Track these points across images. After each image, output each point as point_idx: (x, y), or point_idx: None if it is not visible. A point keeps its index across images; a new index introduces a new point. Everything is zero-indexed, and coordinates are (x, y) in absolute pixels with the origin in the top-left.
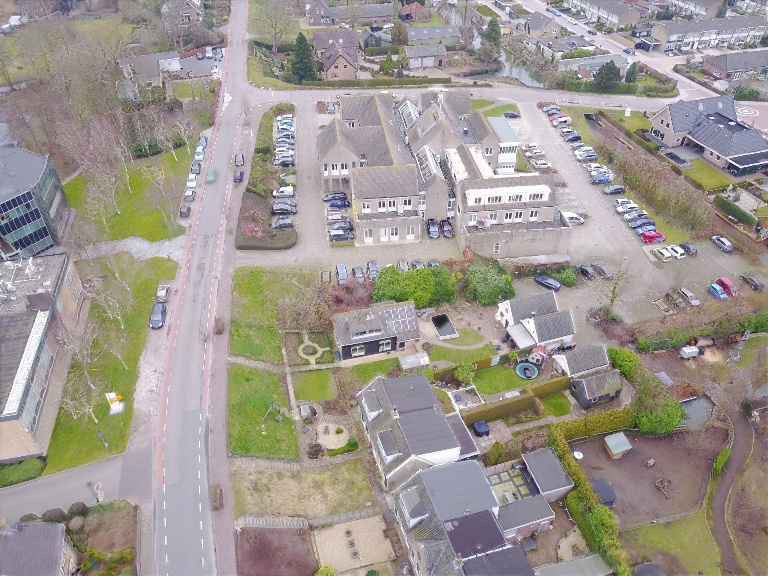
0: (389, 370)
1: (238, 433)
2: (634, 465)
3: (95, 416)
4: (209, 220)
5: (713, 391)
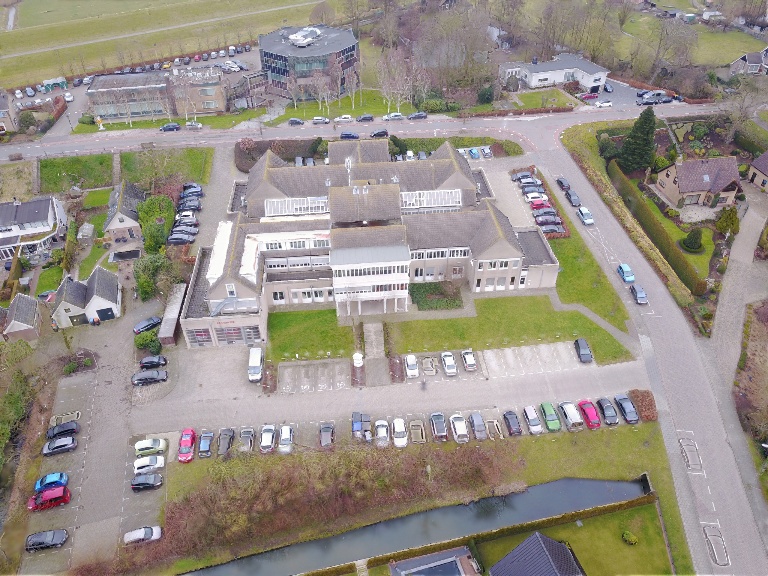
0: (96, 229)
1: (57, 162)
2: None
3: (104, 126)
4: (283, 133)
5: None
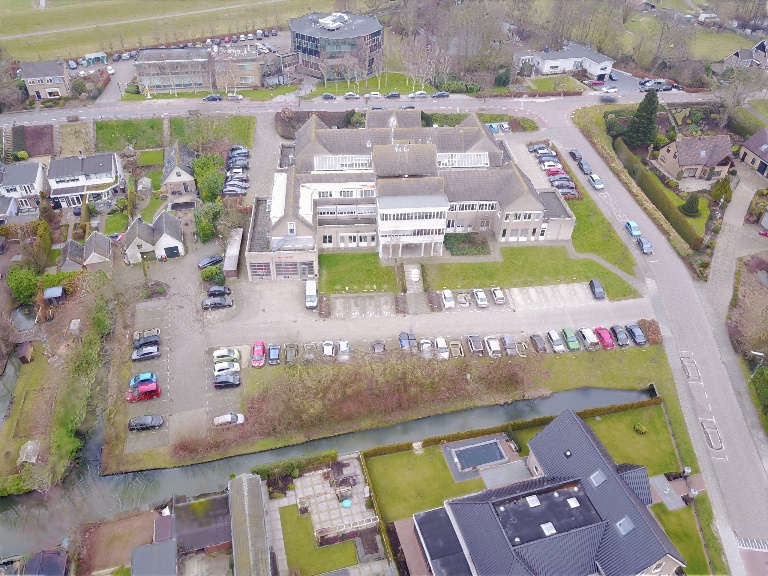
0: None
1: (111, 124)
2: (6, 271)
3: None
4: (317, 105)
5: (33, 334)
